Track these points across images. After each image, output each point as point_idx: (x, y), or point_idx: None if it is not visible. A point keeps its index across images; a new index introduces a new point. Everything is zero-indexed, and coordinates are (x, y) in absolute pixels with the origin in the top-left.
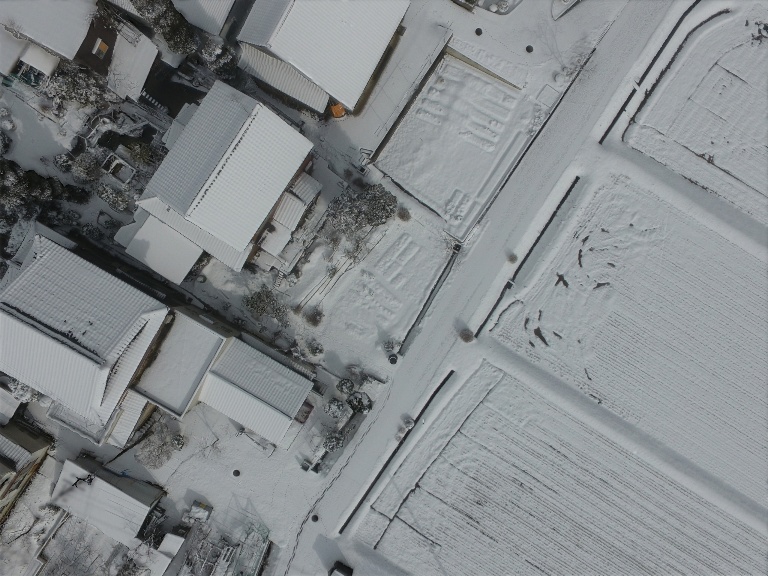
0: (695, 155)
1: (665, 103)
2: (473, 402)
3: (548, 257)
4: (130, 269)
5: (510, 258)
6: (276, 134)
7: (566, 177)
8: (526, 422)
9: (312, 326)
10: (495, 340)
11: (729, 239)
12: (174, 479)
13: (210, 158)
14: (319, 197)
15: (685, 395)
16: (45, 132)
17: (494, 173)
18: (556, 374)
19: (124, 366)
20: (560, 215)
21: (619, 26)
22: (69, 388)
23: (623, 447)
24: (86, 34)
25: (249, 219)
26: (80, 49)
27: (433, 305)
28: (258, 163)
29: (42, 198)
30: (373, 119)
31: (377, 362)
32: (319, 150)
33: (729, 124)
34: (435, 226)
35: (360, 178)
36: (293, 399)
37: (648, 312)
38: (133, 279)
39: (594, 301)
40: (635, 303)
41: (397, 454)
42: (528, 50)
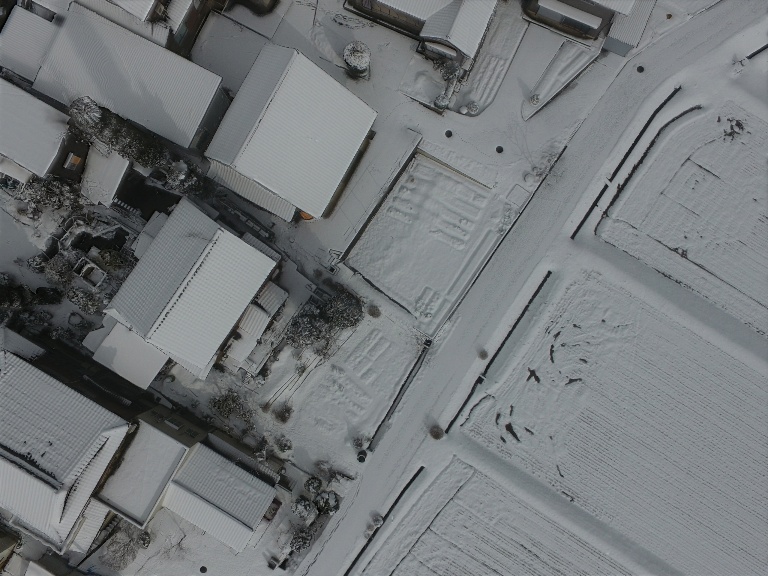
0: (668, 249)
1: (638, 197)
2: (443, 499)
3: (519, 353)
4: (99, 369)
5: (480, 355)
6: (238, 256)
7: (537, 273)
8: (497, 520)
9: (281, 422)
10: (466, 435)
11: (702, 336)
12: (141, 575)
13: (172, 280)
14: (287, 299)
15: (659, 494)
16: (20, 233)
17: (464, 271)
18: (528, 471)
19: (84, 483)
20: (532, 310)
21: (590, 124)
22: (28, 506)
23: (596, 548)
24: (57, 152)
25: (211, 337)
26: (50, 167)
27: (403, 401)
28: (220, 284)
29: (11, 307)
30: (342, 221)
31: (346, 458)
32: (289, 251)
33: (702, 219)
34: (405, 323)
35: (329, 278)
36: (256, 508)
37: (621, 409)
38: (99, 386)
39: (566, 397)
40: (607, 400)
41: (366, 551)
42: (498, 150)
